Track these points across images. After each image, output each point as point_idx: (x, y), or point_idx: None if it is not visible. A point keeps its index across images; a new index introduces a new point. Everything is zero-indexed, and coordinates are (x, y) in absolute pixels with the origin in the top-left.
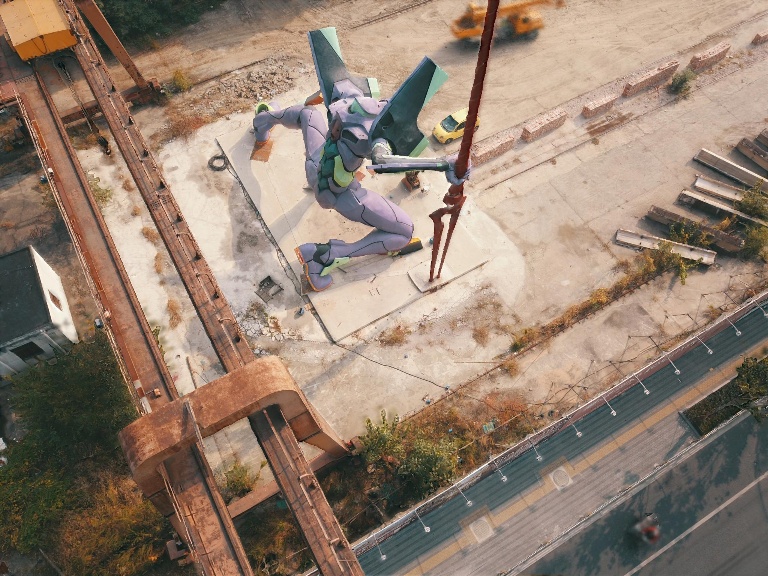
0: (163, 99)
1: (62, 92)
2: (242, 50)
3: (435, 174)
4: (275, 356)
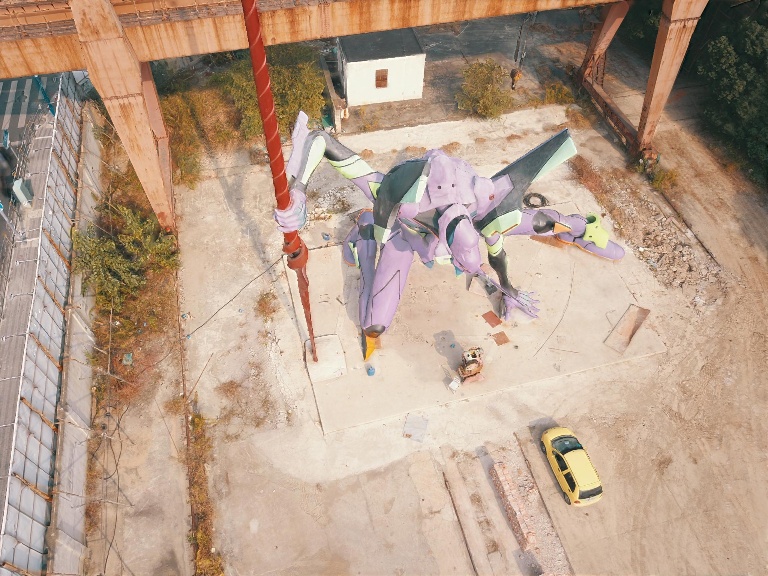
0: None
1: None
2: (736, 245)
3: (484, 412)
4: None
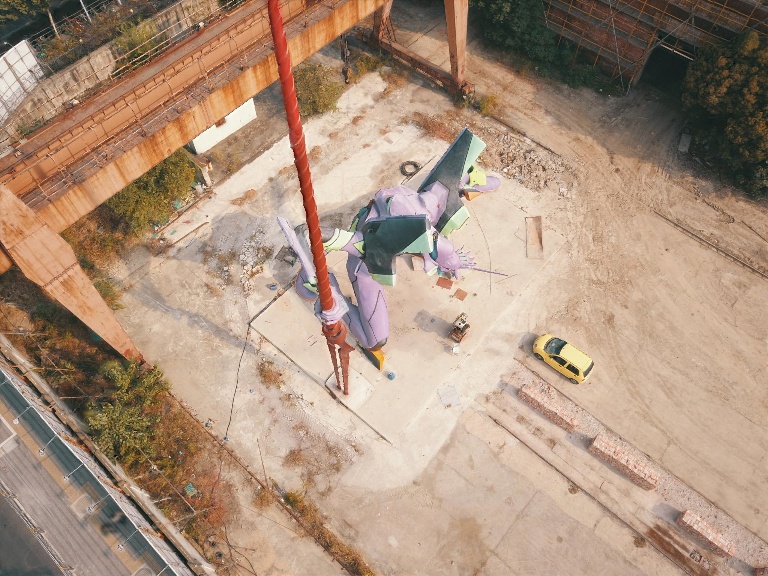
0: None
1: (434, 40)
2: (560, 134)
3: (486, 356)
4: None
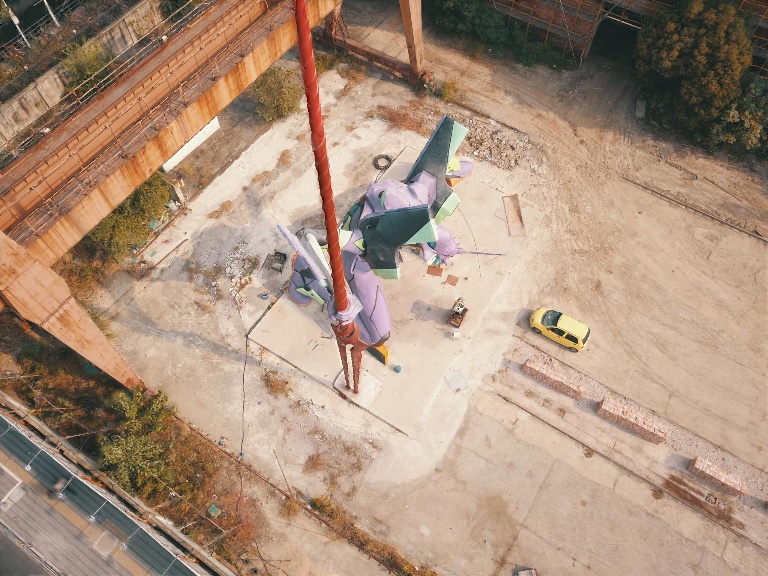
0: (423, 92)
1: (386, 33)
2: (522, 112)
3: (486, 337)
4: (3, 234)
